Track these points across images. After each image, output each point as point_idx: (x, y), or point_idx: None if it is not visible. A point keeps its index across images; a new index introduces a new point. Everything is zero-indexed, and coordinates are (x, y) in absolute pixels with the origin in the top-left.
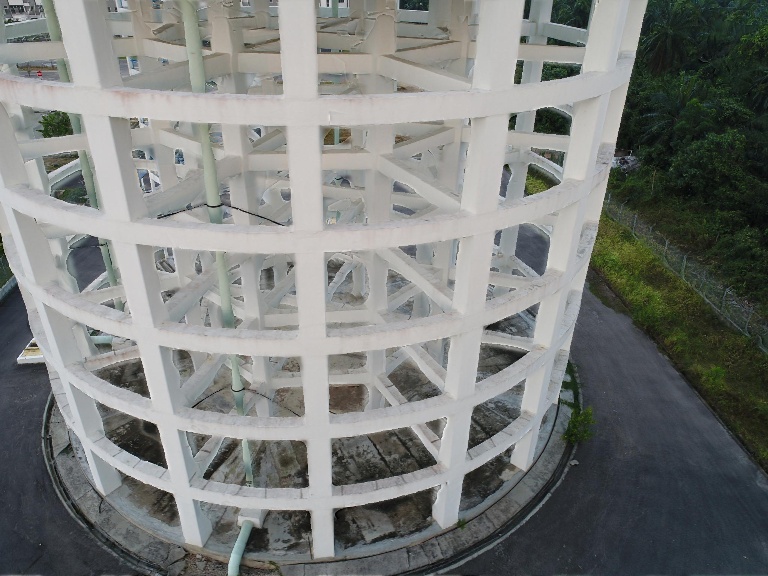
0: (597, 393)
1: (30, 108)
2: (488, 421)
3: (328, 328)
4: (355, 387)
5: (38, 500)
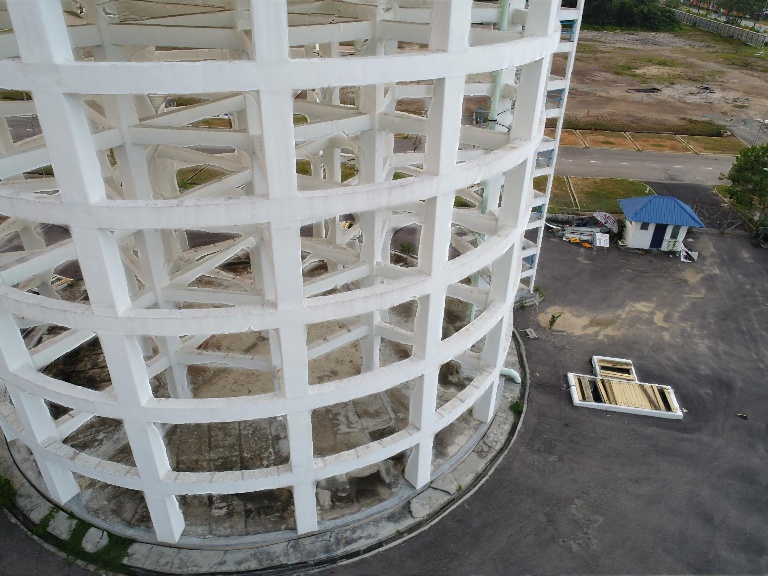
0: (42, 575)
1: (312, 48)
2: (83, 426)
3: (1, 153)
4: (199, 347)
5: (201, 242)
